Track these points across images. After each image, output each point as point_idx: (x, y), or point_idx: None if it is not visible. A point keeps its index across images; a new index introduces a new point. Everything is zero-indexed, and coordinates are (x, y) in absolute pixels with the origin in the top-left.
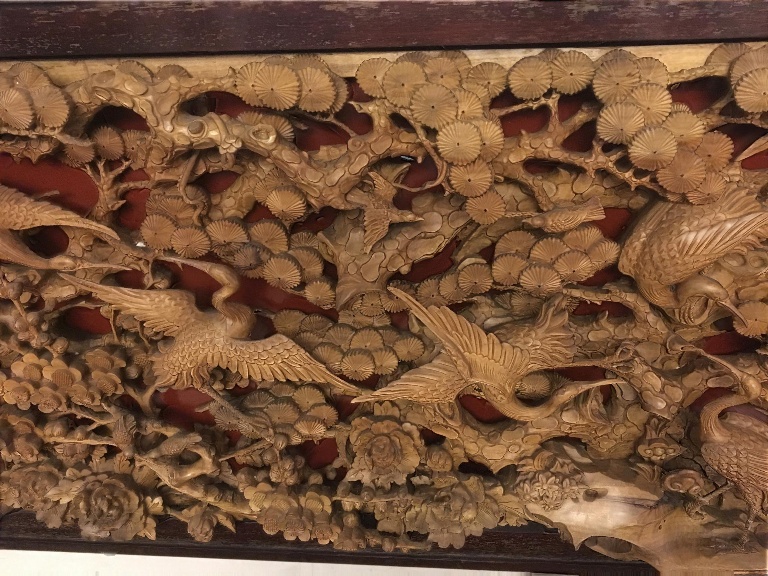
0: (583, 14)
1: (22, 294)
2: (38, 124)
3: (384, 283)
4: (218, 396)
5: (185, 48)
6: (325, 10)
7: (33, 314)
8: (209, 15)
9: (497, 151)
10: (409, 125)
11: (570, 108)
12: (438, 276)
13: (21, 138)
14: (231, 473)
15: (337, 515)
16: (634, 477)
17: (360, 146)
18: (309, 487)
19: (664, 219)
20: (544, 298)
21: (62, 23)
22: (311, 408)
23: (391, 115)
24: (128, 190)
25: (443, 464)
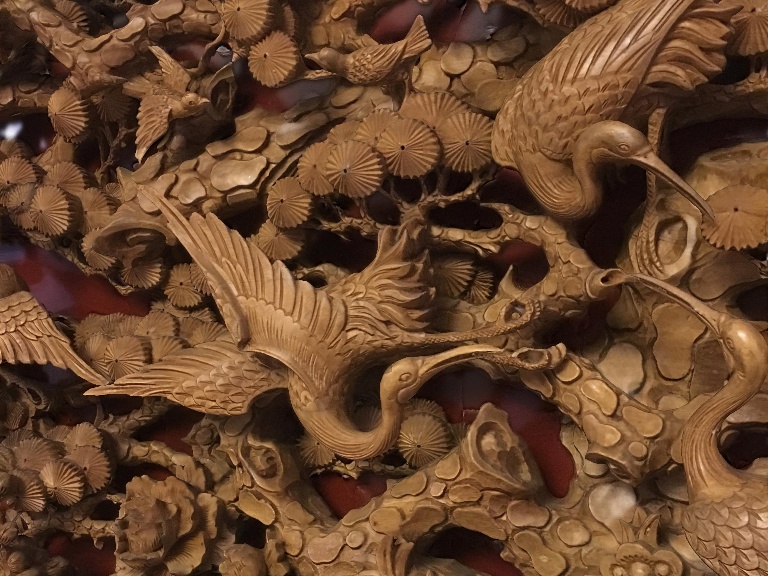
0: None
1: None
2: None
3: None
4: None
5: None
6: None
7: None
8: None
9: None
10: None
11: None
12: None
13: None
14: None
15: None
16: None
17: (137, 8)
18: None
19: None
20: None
21: None
22: None
23: None
24: None
25: (240, 567)
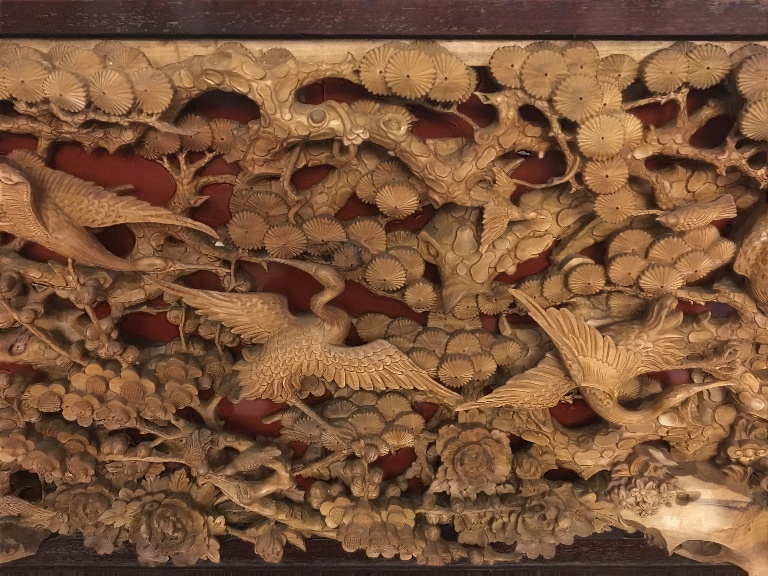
0: (724, 6)
1: None
2: (133, 110)
3: (490, 284)
4: (305, 407)
5: (298, 30)
6: None
7: (107, 321)
8: None
9: (634, 146)
10: (536, 118)
11: (695, 103)
12: (538, 277)
13: (98, 126)
14: (295, 487)
15: (418, 528)
16: (724, 479)
17: (489, 139)
18: (388, 500)
19: None
20: (650, 299)
21: None
22: (399, 417)
23: (520, 107)
24: (207, 185)
25: (534, 472)
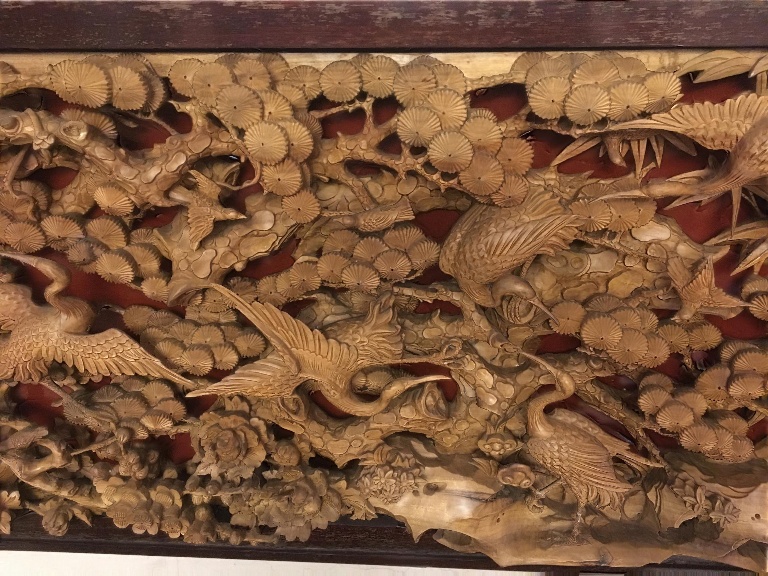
0: (387, 21)
1: None
2: None
3: (218, 280)
4: (60, 390)
5: (6, 45)
6: (140, 11)
7: None
8: (26, 13)
9: (307, 152)
10: None
11: (387, 111)
12: (277, 273)
13: None
14: None
15: (189, 509)
16: (474, 471)
17: (176, 144)
18: (162, 481)
19: (477, 220)
20: (376, 296)
21: None
22: (158, 403)
23: (208, 115)
24: None
25: (289, 458)
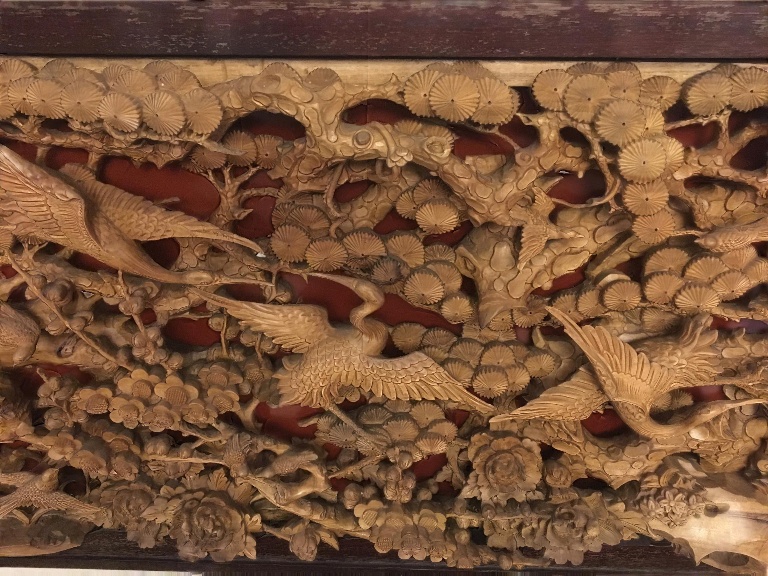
0: None
1: None
2: (183, 130)
3: (526, 299)
4: (342, 414)
5: (343, 51)
6: (501, 16)
7: (154, 330)
8: (375, 17)
9: (674, 169)
10: (576, 139)
11: (736, 124)
12: (573, 291)
13: (147, 142)
14: None
15: (449, 532)
16: (753, 492)
17: (530, 161)
18: (420, 503)
19: None
20: (685, 315)
21: (211, 20)
22: (432, 425)
23: (562, 129)
24: (249, 197)
25: (564, 480)
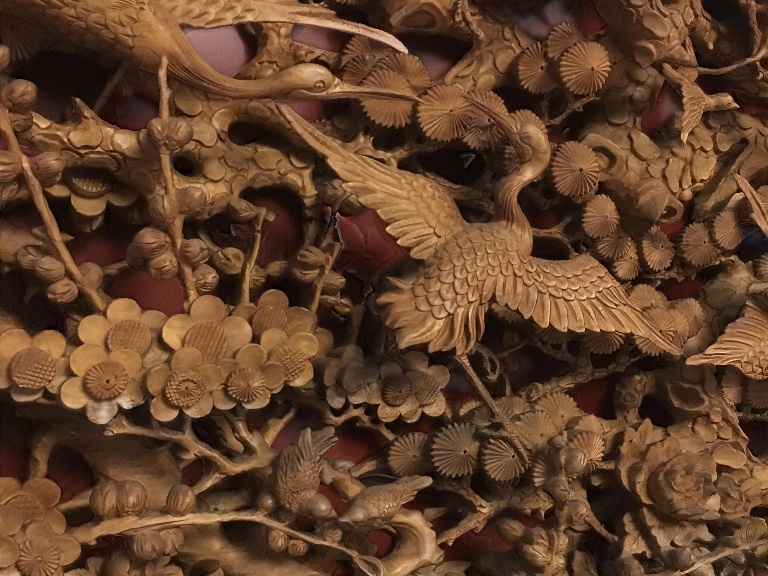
0: None
1: (84, 202)
2: None
3: None
4: (478, 379)
5: None
6: None
7: (197, 187)
8: None
9: None
10: None
11: None
12: None
13: None
14: None
15: None
16: None
17: None
18: None
19: None
20: None
21: None
22: (577, 420)
23: None
24: None
25: (744, 505)
